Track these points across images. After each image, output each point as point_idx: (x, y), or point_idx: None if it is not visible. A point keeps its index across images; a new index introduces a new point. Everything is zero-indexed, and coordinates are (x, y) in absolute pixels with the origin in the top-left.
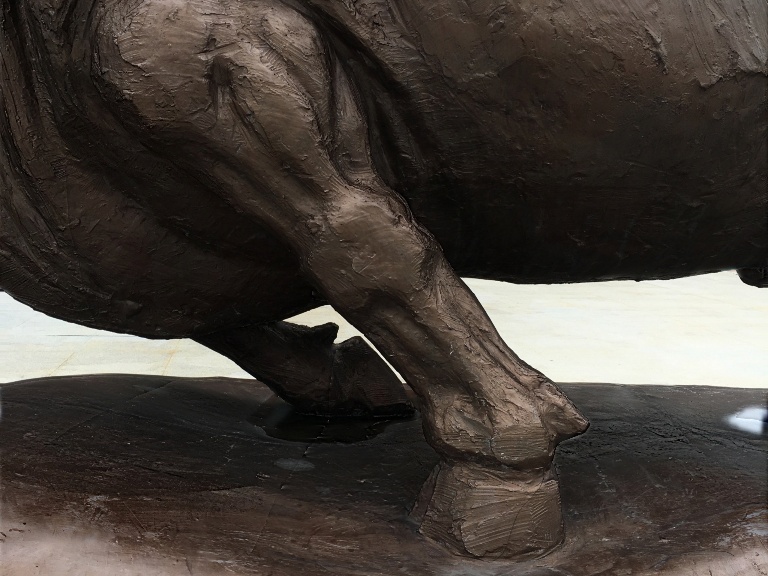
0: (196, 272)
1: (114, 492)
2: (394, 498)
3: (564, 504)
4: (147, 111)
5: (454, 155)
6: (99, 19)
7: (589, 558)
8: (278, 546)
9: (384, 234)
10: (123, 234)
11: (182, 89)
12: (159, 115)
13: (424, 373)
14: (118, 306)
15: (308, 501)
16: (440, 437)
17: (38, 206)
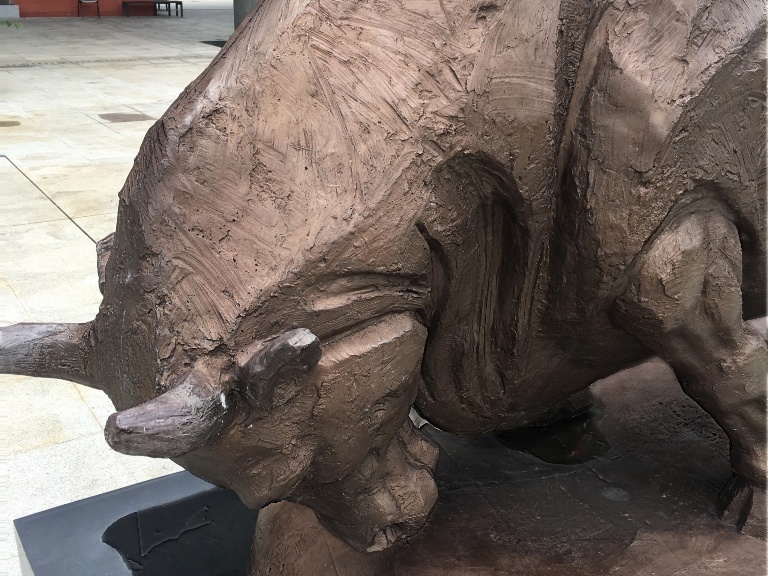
0: (570, 381)
1: (599, 571)
2: (697, 507)
3: None
4: (669, 324)
5: (764, 282)
6: (643, 263)
7: None
8: (699, 575)
9: (764, 364)
10: (547, 374)
11: (692, 305)
12: (674, 325)
13: (754, 437)
14: (515, 417)
15: (672, 530)
16: (764, 476)
17: (505, 372)
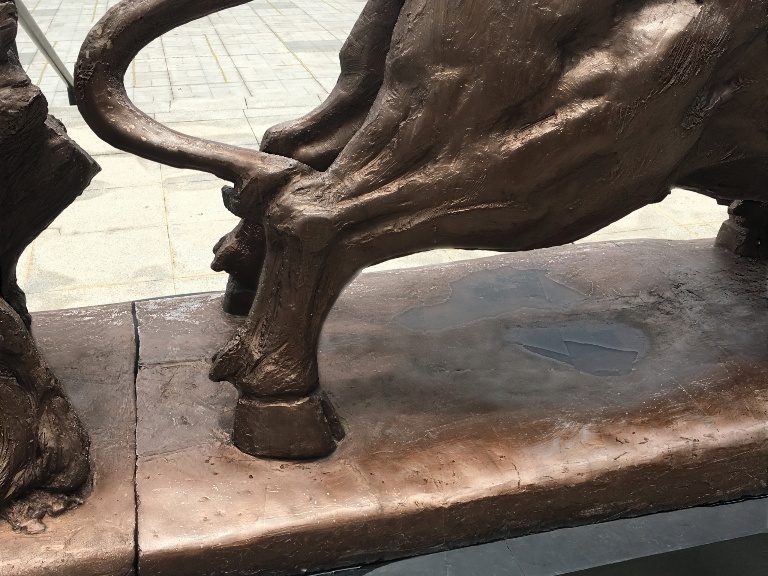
0: None
1: None
2: None
3: (723, 253)
4: None
5: None
6: None
7: None
8: None
9: None
10: None
11: None
12: None
13: None
14: None
15: None
16: None
17: None
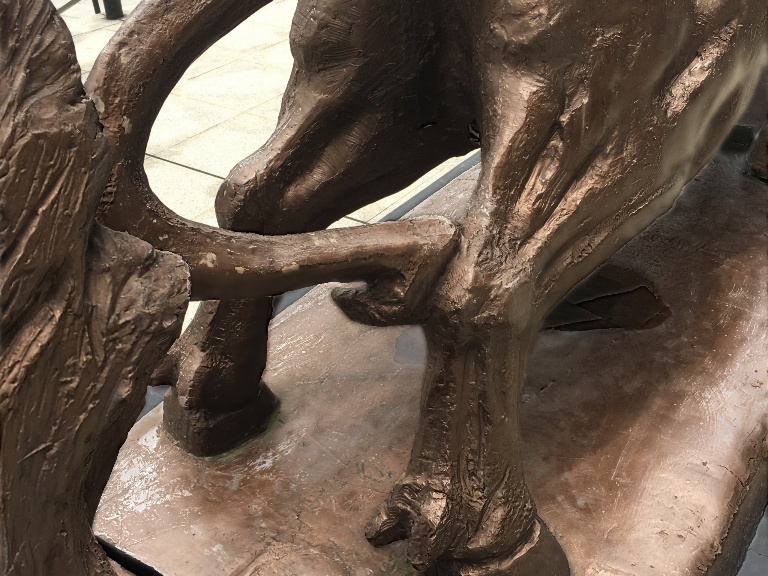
0: None
1: None
2: None
3: None
4: None
5: None
6: None
7: None
8: None
9: None
10: None
11: None
12: None
13: None
14: None
15: None
16: None
17: None
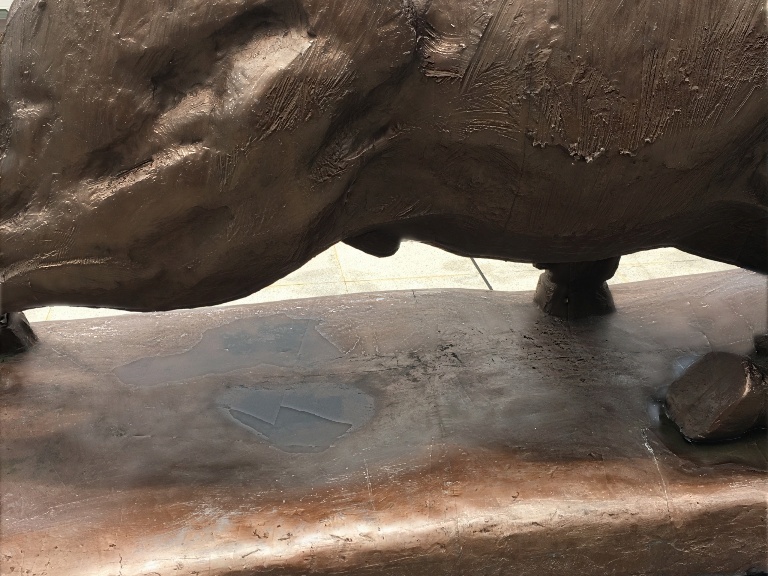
0: None
1: None
2: None
3: (533, 310)
4: None
5: None
6: None
7: (521, 298)
8: (666, 289)
9: None
10: None
11: None
12: None
13: None
14: None
15: None
16: None
17: None
